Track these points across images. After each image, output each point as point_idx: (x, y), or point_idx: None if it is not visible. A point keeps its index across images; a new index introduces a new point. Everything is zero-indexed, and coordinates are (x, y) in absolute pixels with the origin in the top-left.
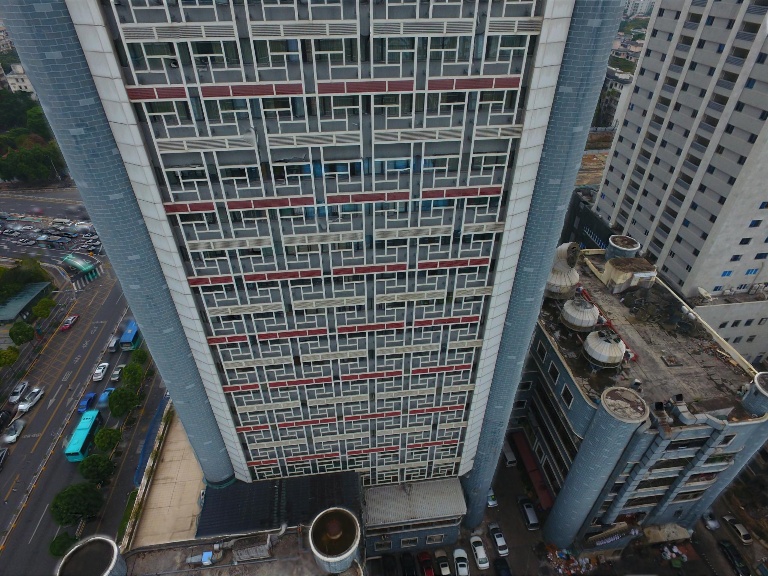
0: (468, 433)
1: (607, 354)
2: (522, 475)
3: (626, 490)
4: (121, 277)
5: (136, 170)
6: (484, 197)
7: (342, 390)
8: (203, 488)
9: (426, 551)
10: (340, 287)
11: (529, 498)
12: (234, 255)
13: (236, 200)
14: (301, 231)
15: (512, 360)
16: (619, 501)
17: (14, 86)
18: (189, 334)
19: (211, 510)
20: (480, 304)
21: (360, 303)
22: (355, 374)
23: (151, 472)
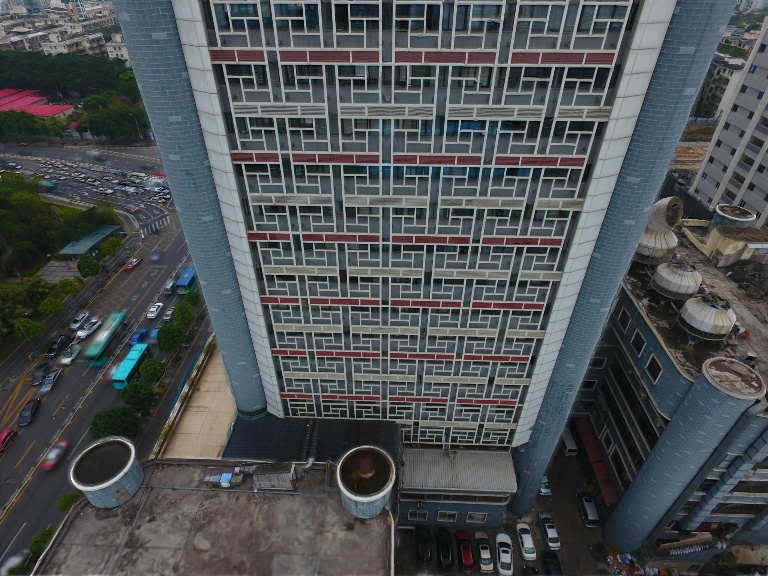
0: (529, 394)
1: (711, 322)
2: (583, 466)
3: (719, 489)
4: (161, 144)
5: (182, 1)
6: (590, 67)
7: (390, 318)
8: (234, 420)
9: (465, 529)
10: (400, 182)
11: (589, 492)
12: (283, 126)
13: (290, 49)
14: (361, 99)
15: (595, 304)
16: (708, 502)
17: (112, 54)
18: (229, 227)
19: (239, 439)
20: (565, 223)
21: (421, 205)
22: (407, 299)
23: (185, 398)
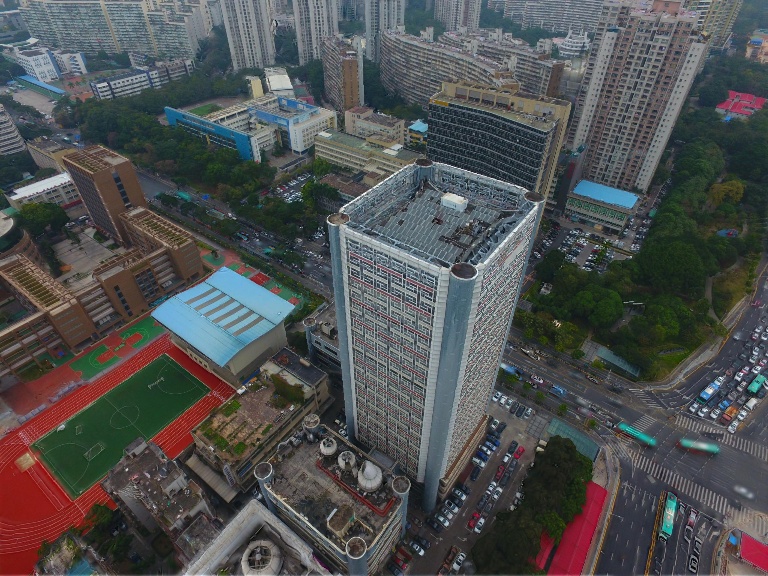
0: None
1: None
2: None
3: None
4: None
5: None
6: None
7: None
8: None
9: None
10: None
11: None
12: None
13: None
14: None
15: None
16: None
17: None
18: None
19: None
20: None
21: None
22: None
23: None
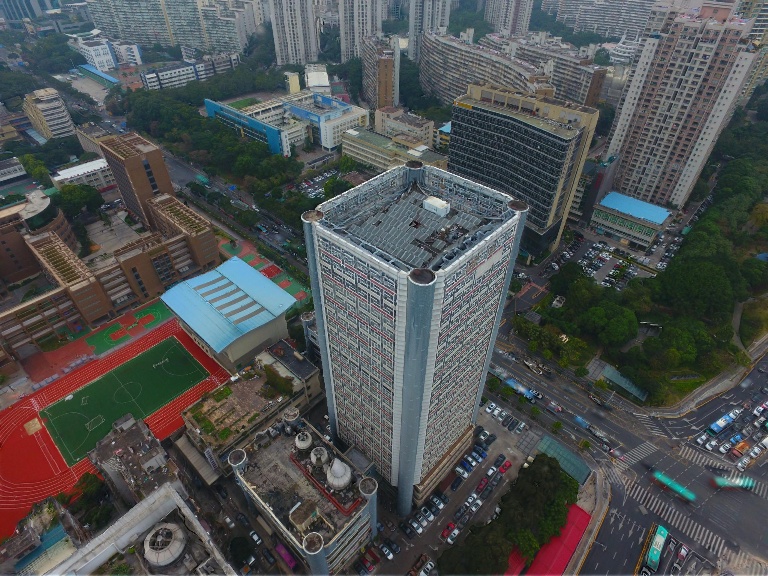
0: None
1: None
2: None
3: None
4: None
5: None
6: None
7: None
8: None
9: None
10: None
11: None
12: None
13: None
14: None
15: None
16: None
17: None
18: None
19: None
20: None
21: None
22: None
23: None
